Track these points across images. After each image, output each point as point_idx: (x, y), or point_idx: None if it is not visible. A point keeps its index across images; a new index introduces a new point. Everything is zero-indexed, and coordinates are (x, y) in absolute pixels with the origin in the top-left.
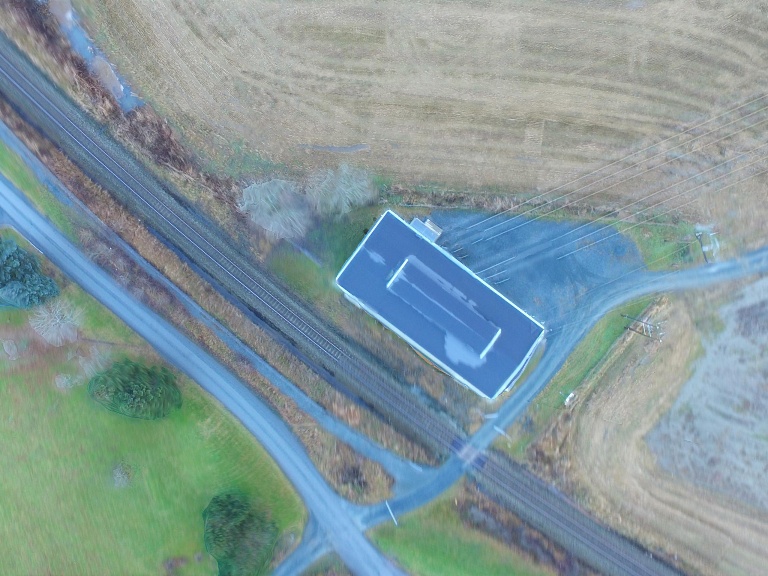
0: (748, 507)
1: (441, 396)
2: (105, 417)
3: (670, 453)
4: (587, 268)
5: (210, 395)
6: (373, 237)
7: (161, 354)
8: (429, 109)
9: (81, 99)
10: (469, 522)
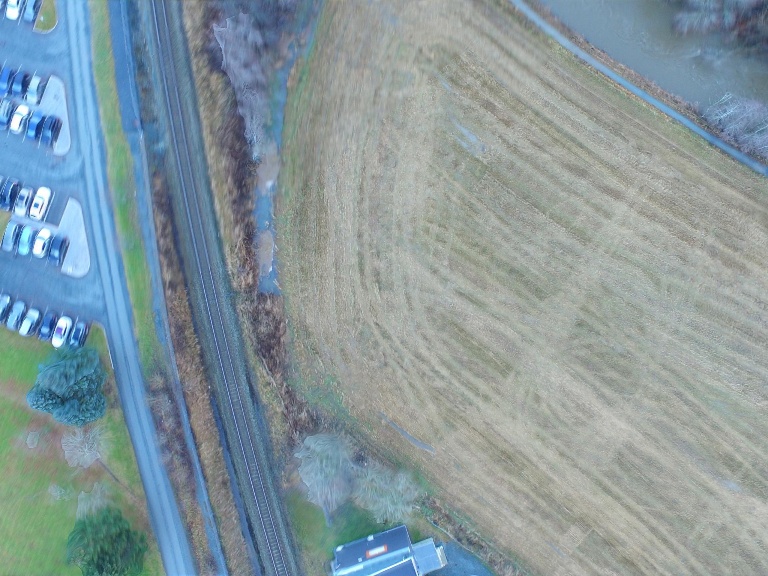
0: None
1: None
2: (69, 532)
3: None
4: None
5: (165, 575)
6: (384, 573)
7: (150, 514)
8: (505, 456)
9: (232, 261)
10: None
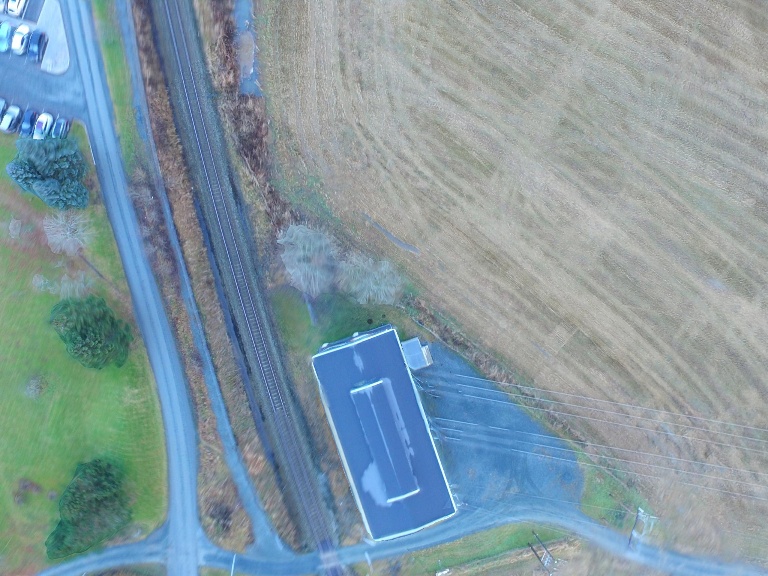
0: None
1: (340, 497)
2: None
3: None
4: (531, 473)
5: (151, 371)
6: (367, 343)
7: (135, 310)
8: (490, 256)
9: (212, 59)
10: None
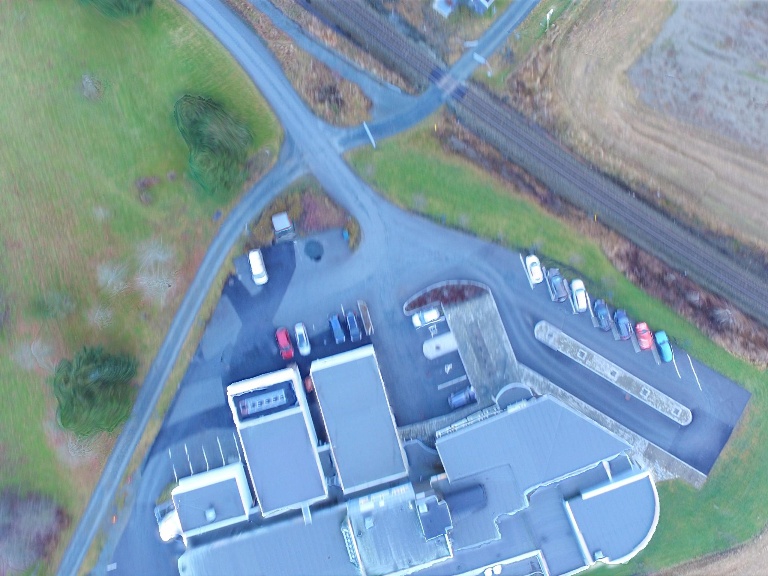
0: (731, 142)
1: (420, 24)
2: (74, 31)
3: (652, 88)
4: None
5: (182, 7)
6: None
7: None
8: None
9: None
10: (449, 147)
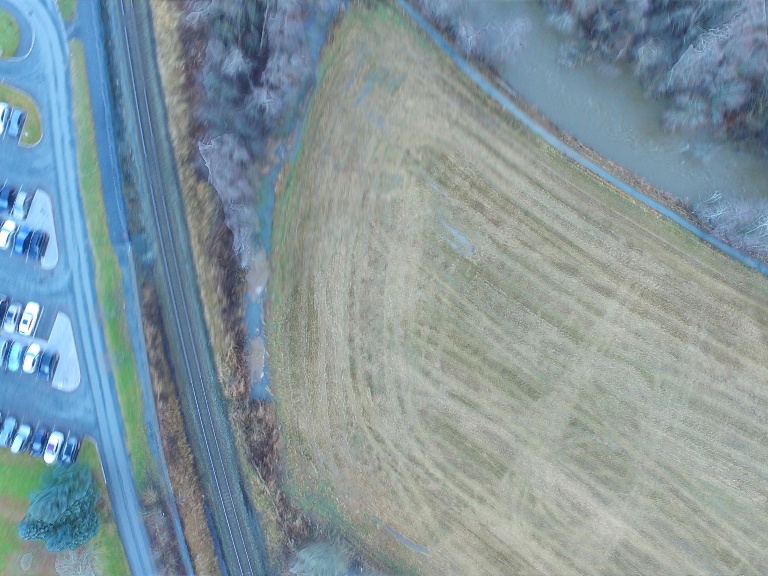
0: None
1: None
2: None
3: None
4: None
5: None
6: None
7: None
8: (501, 557)
9: (223, 369)
10: None
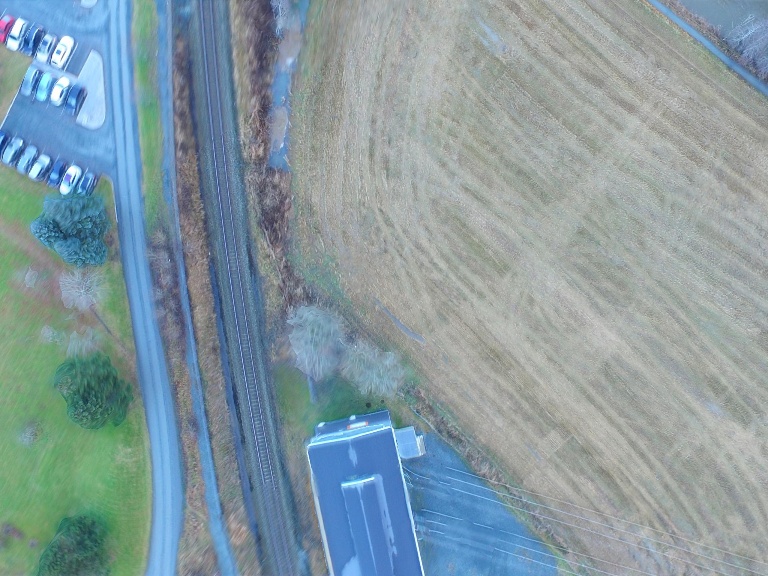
0: None
1: (317, 575)
2: None
3: None
4: (510, 574)
5: (147, 431)
6: (363, 438)
7: (138, 369)
8: (494, 354)
9: (245, 131)
10: None
